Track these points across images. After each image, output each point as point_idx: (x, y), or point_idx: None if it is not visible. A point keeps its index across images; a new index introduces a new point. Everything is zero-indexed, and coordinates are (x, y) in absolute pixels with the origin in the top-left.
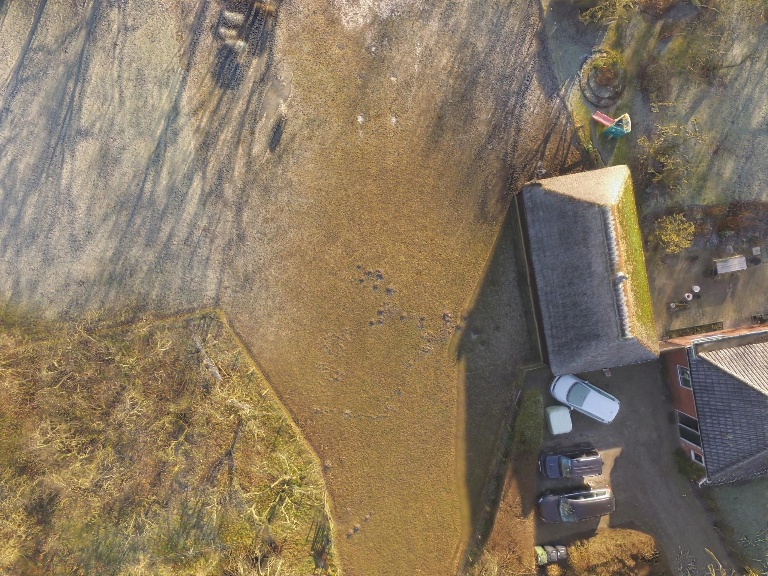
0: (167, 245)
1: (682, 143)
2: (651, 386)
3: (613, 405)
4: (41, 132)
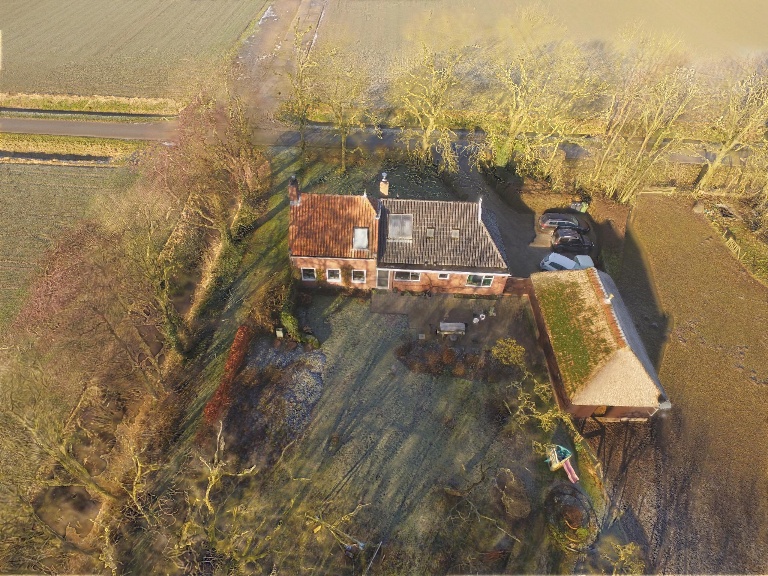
0: None
1: (513, 416)
2: None
3: (554, 260)
4: None
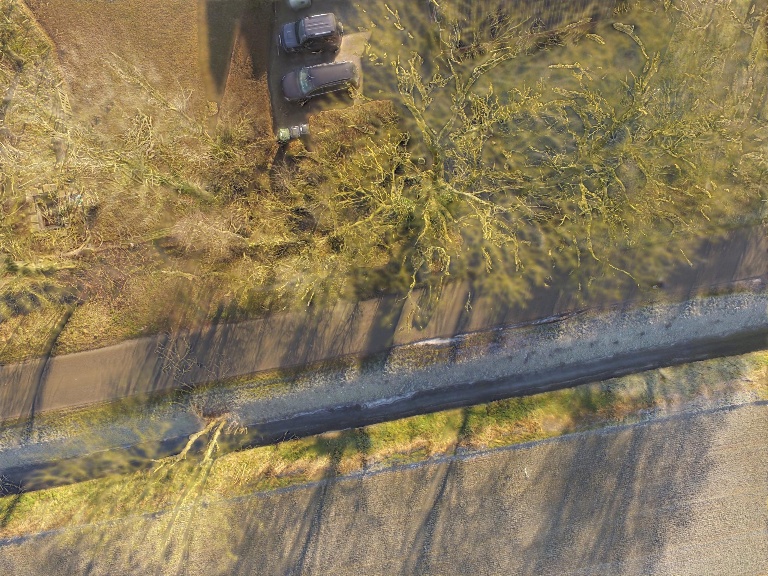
0: None
1: None
2: None
3: None
4: None
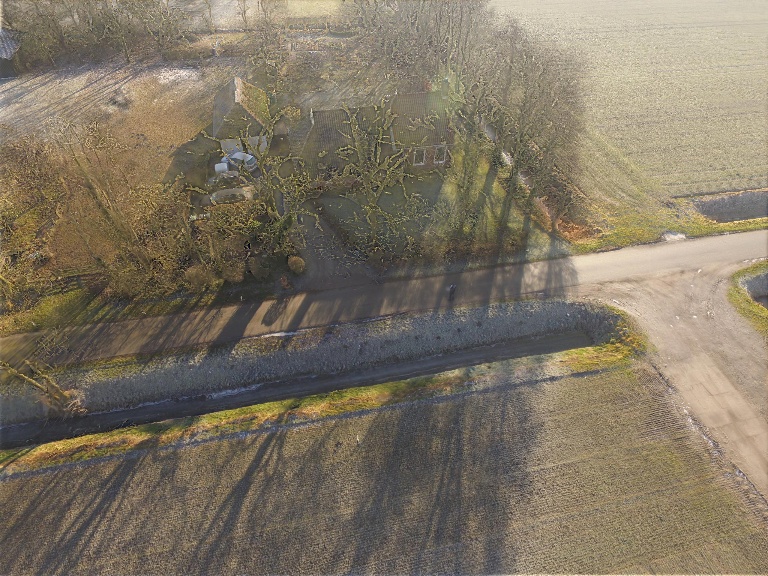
0: (36, 128)
1: None
2: (283, 164)
3: None
4: (1, 103)
